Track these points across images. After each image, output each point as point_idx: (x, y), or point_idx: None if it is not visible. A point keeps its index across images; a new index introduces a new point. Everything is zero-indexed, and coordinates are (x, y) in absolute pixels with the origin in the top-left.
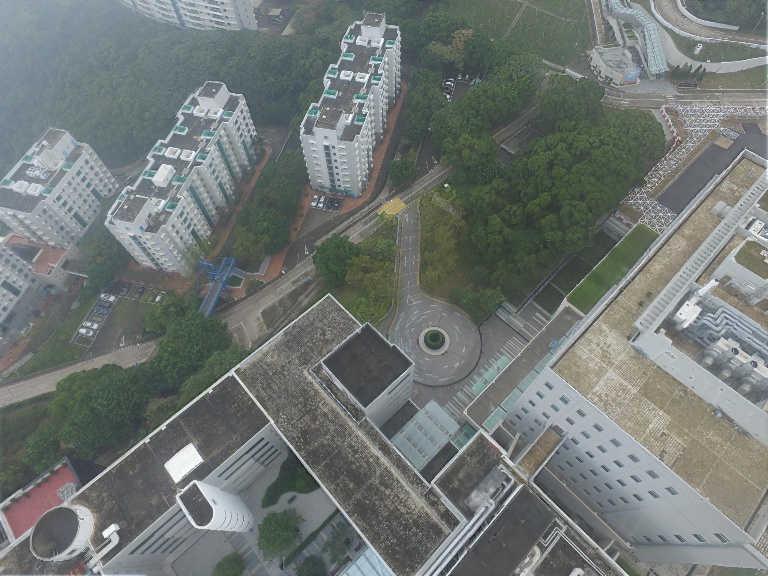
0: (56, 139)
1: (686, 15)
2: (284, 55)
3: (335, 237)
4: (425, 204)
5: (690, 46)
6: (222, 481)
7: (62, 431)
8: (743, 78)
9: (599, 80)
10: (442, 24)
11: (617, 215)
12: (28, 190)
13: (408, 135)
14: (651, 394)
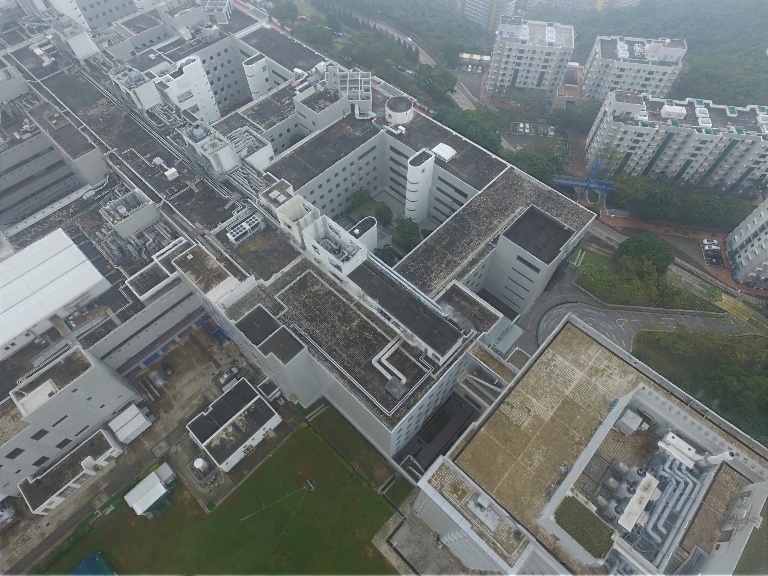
0: (676, 46)
1: None
2: None
3: (668, 248)
4: (759, 341)
5: None
6: (435, 186)
7: (452, 116)
8: None
9: None
10: None
11: None
12: (621, 51)
13: None
14: (568, 408)
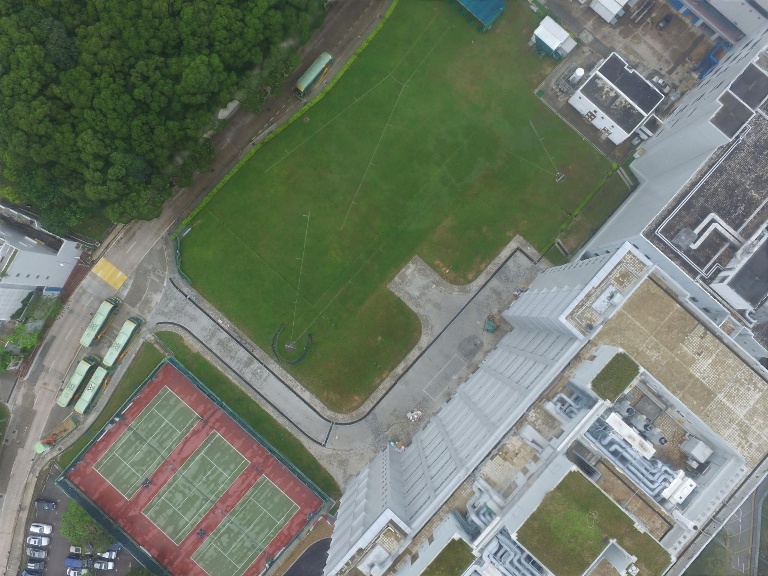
0: None
1: None
2: None
3: None
4: None
5: None
6: None
7: None
8: None
9: None
10: None
11: None
12: None
13: None
14: (704, 394)
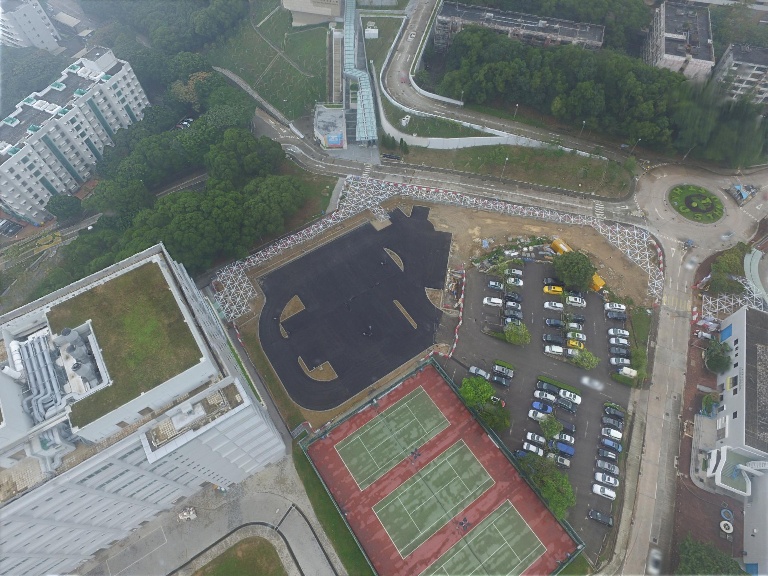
0: None
1: (412, 84)
2: (43, 76)
3: None
4: None
5: (398, 117)
6: None
7: None
8: (453, 157)
9: (313, 139)
10: (183, 64)
11: (213, 285)
12: None
13: (97, 171)
14: None
